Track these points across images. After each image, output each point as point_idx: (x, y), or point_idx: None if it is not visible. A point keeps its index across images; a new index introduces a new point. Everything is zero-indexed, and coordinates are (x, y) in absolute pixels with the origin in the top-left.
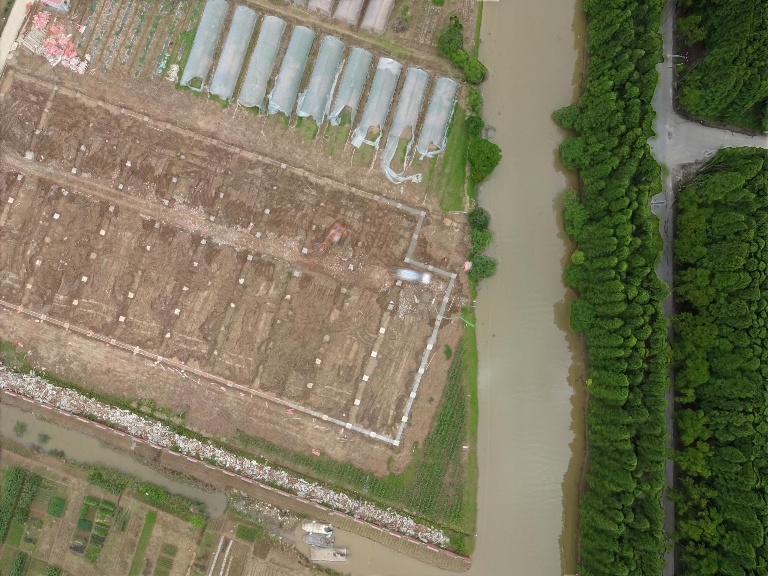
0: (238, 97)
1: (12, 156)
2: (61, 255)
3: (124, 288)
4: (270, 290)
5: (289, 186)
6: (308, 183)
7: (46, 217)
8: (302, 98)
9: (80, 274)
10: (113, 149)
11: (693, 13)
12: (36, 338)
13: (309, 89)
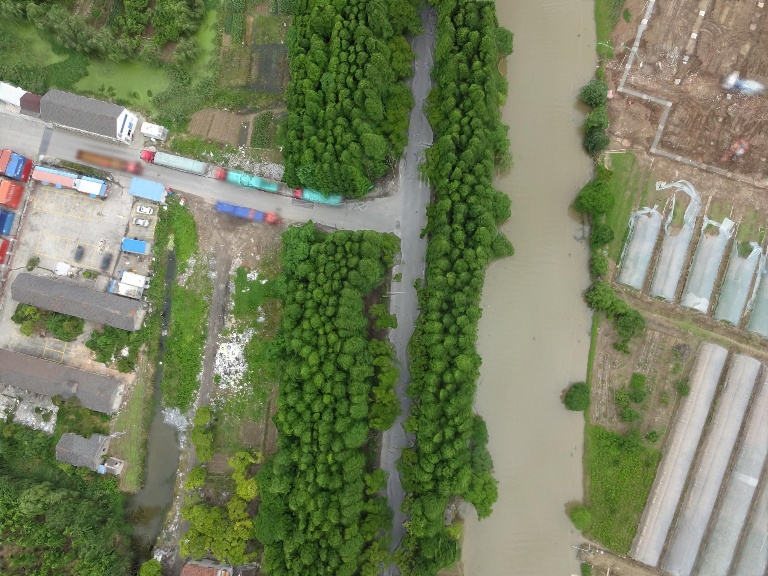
0: None
1: None
2: None
3: None
4: None
5: None
6: None
7: None
8: None
9: None
10: None
11: (377, 338)
12: None
13: None
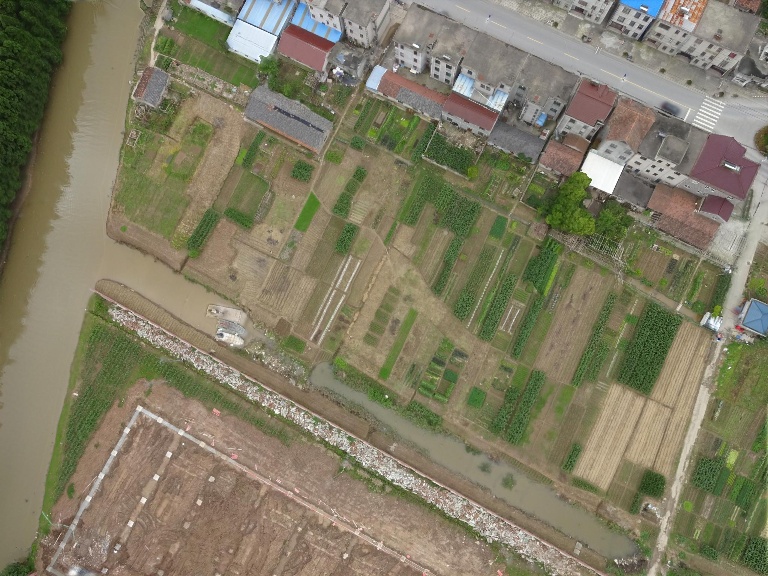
0: None
1: None
2: None
3: None
4: None
5: None
6: None
7: None
8: None
9: None
10: None
11: None
12: None
13: None
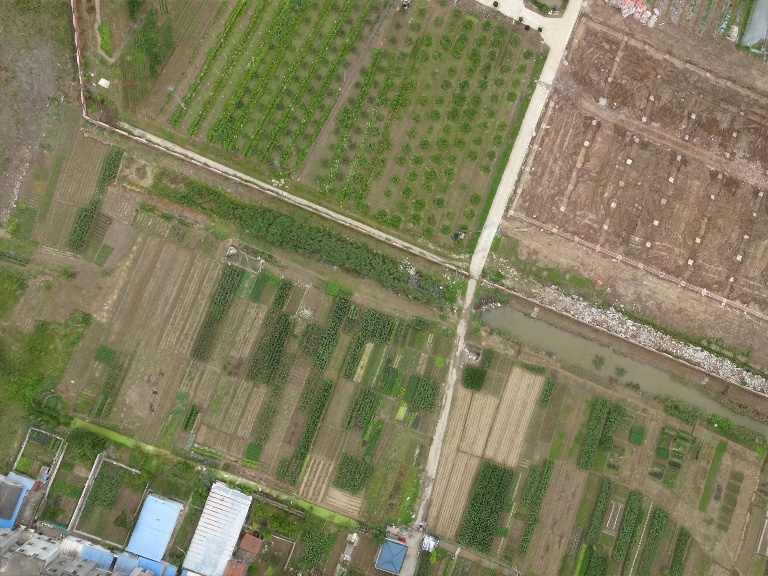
0: None
1: (588, 101)
2: (636, 199)
3: (693, 233)
4: None
5: None
6: None
7: (622, 162)
8: None
9: (653, 218)
10: (681, 101)
11: None
12: (614, 277)
13: None
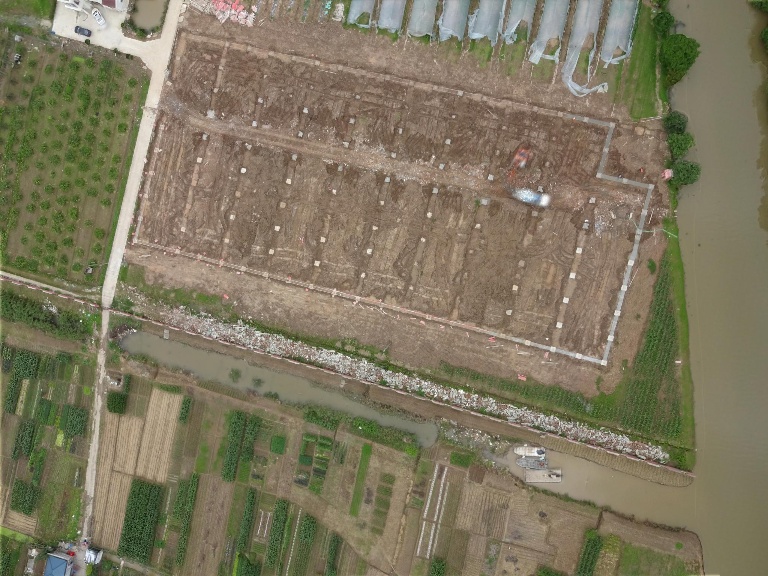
0: (407, 28)
1: (195, 117)
2: (253, 208)
3: (316, 233)
4: (460, 221)
5: (468, 113)
6: (488, 107)
7: (234, 172)
8: (473, 20)
9: (273, 224)
10: (289, 98)
11: None
12: (239, 289)
13: (480, 9)
